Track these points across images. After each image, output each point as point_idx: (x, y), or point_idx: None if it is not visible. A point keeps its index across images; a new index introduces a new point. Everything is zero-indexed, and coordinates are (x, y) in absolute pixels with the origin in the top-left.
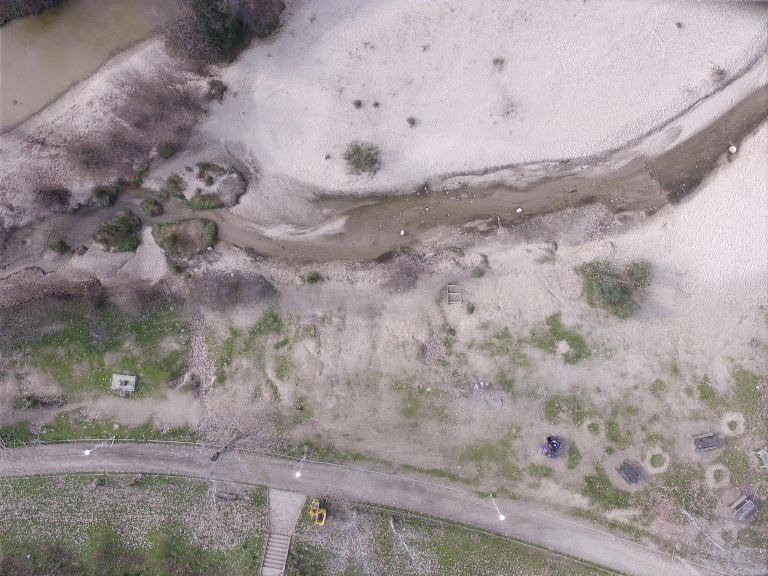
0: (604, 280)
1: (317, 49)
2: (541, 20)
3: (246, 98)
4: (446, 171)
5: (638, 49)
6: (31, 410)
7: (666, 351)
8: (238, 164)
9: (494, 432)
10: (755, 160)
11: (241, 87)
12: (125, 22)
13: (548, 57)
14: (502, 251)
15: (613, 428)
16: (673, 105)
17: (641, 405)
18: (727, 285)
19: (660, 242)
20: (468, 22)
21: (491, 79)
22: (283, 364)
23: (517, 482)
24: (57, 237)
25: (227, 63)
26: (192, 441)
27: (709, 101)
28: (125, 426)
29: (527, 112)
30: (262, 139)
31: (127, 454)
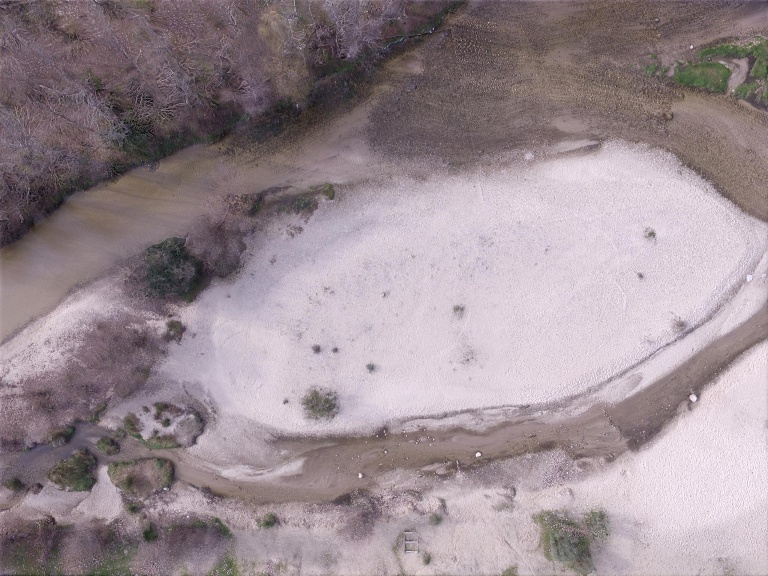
0: (562, 529)
1: (277, 292)
2: (502, 268)
3: (205, 339)
4: (405, 415)
5: (599, 298)
6: None
7: None
8: (196, 404)
9: None
10: (715, 411)
11: (200, 328)
12: (85, 259)
13: (509, 305)
14: (460, 495)
15: None
16: (634, 354)
17: None
18: (686, 536)
19: (619, 490)
20: (429, 269)
21: (451, 326)
22: None
23: None
24: (12, 475)
25: (187, 302)
26: None
27: (670, 349)
28: None
29: (487, 360)
30: (220, 380)
31: None
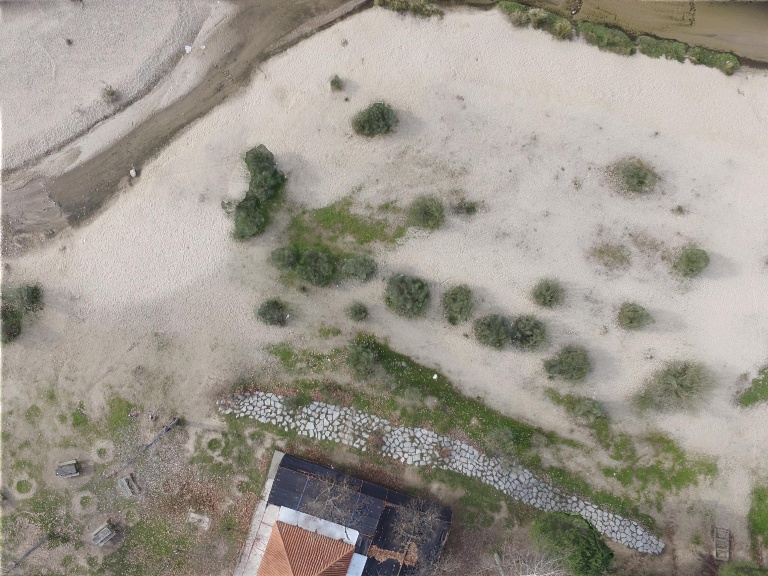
0: None
1: None
2: None
3: None
4: None
5: (27, 66)
6: None
7: (46, 377)
8: None
9: None
10: (152, 185)
11: None
12: None
13: None
14: None
15: None
16: (67, 125)
17: (14, 431)
18: (122, 311)
19: (57, 266)
20: None
21: None
22: None
23: None
24: None
25: None
26: None
27: (109, 122)
28: None
29: None
30: None
31: None
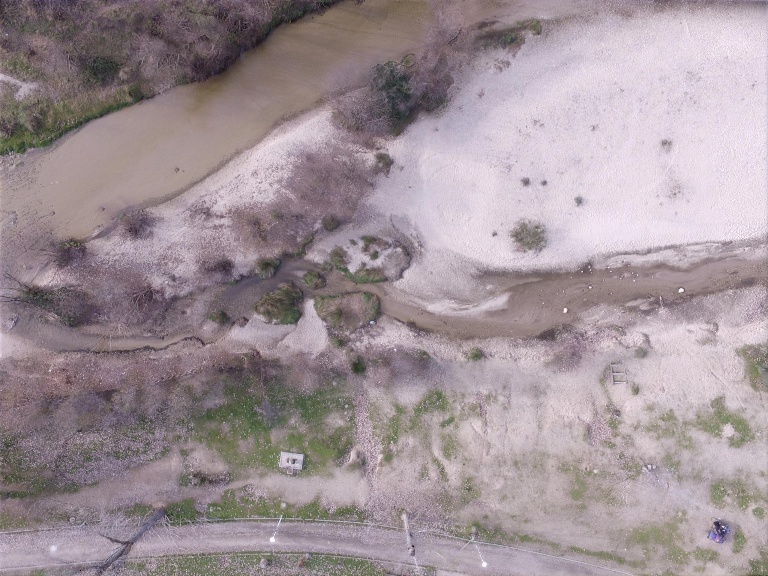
0: (765, 362)
1: (486, 125)
2: (710, 103)
3: (413, 172)
4: (610, 250)
5: None
6: (197, 488)
7: None
8: (402, 238)
9: (660, 515)
10: None
11: (408, 161)
12: (291, 91)
13: (716, 140)
14: (663, 331)
15: None
16: None
17: None
18: None
19: None
20: (638, 103)
21: (659, 160)
22: (449, 443)
23: (683, 565)
24: (218, 308)
25: (394, 136)
26: (359, 521)
27: None
28: (292, 505)
29: (694, 194)
30: (428, 214)
31: (294, 533)
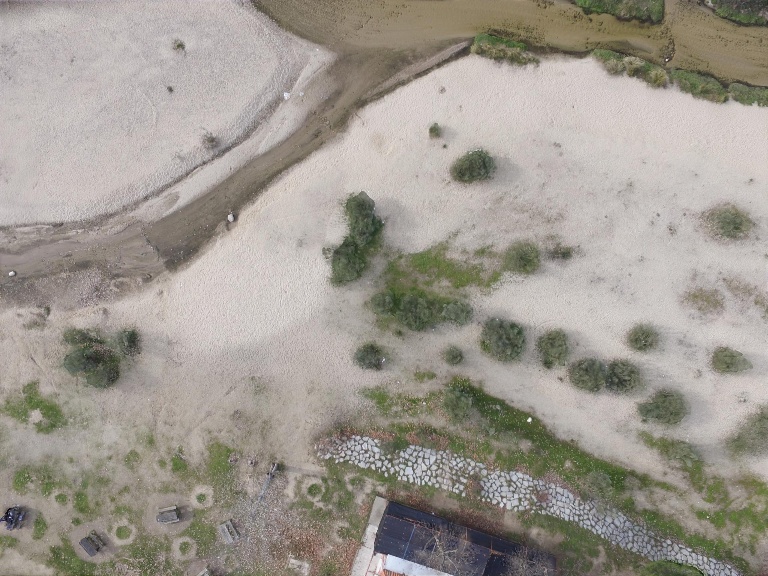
0: (93, 347)
1: None
2: (26, 79)
3: None
4: None
5: (129, 113)
6: None
7: (144, 422)
8: None
9: None
10: (250, 230)
11: None
12: None
13: (34, 117)
14: None
15: (82, 499)
16: (167, 171)
17: (113, 476)
18: (219, 355)
19: (154, 310)
20: None
21: None
22: None
23: None
24: None
25: None
26: None
27: (208, 168)
28: None
29: (12, 174)
30: None
31: None
